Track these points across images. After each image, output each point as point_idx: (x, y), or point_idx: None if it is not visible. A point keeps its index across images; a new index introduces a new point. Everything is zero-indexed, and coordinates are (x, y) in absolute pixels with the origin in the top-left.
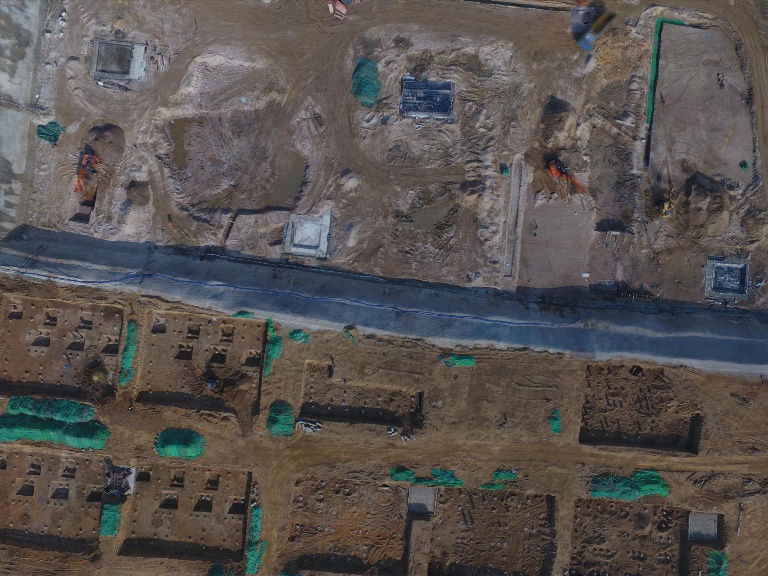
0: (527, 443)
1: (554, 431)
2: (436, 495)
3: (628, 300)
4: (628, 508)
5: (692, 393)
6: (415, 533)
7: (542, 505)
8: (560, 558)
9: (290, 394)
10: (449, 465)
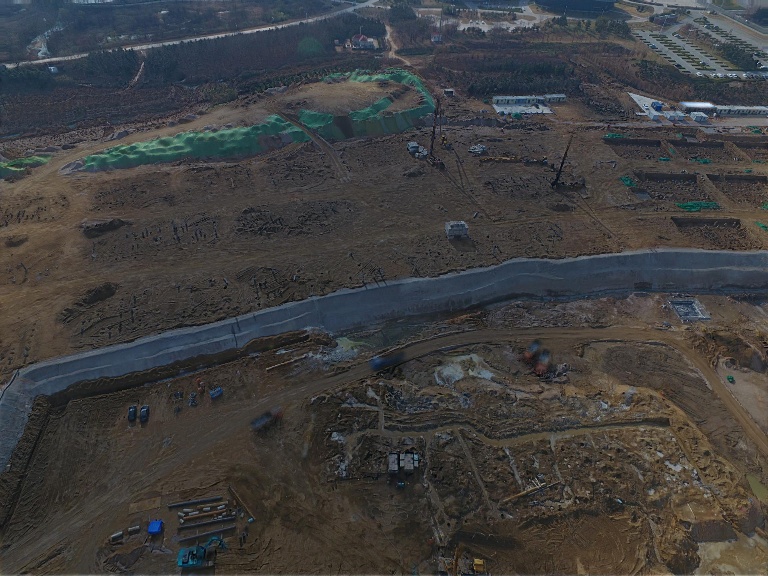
0: None
1: (759, 223)
2: None
3: None
4: None
5: None
6: None
7: None
8: None
9: None
10: None
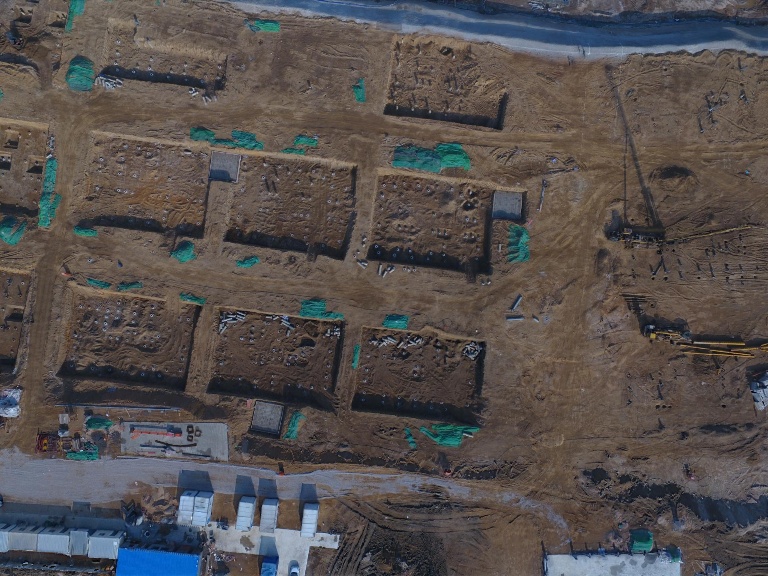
0: (330, 111)
1: (358, 100)
2: (239, 163)
3: (450, 0)
4: (434, 186)
5: (499, 70)
6: (213, 193)
7: (347, 178)
8: (360, 225)
9: (92, 51)
10: (250, 128)
